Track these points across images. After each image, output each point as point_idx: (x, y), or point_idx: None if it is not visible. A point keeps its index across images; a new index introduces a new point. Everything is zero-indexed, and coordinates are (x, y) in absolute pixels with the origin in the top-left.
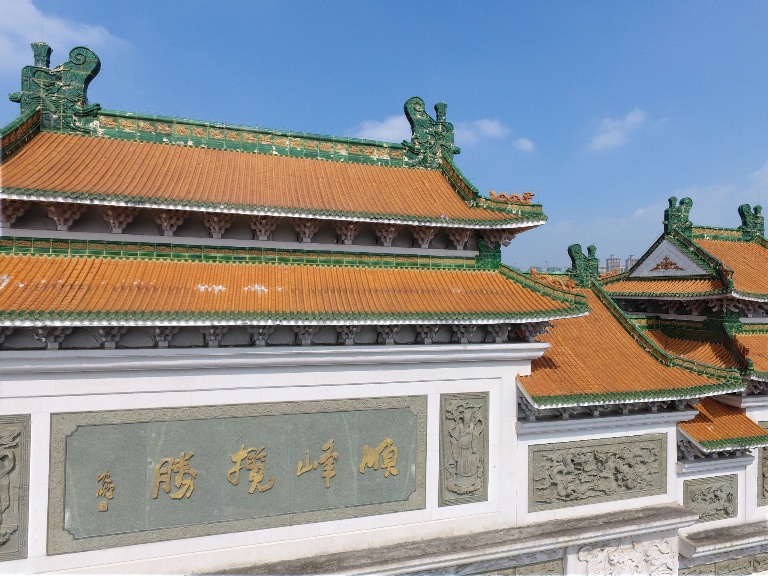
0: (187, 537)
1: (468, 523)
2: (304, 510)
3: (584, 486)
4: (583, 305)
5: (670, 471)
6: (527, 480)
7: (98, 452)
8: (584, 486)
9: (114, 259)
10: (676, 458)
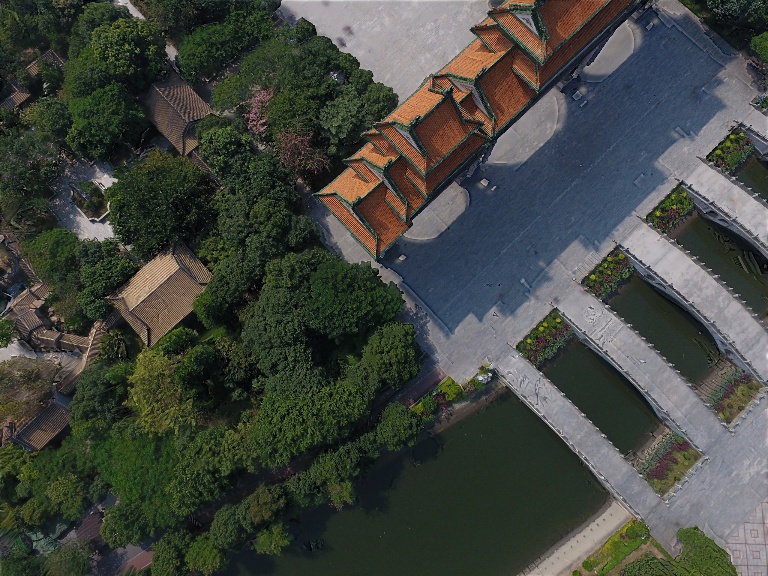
0: None
1: None
2: None
3: None
4: None
5: None
6: None
7: None
8: None
9: None
10: None
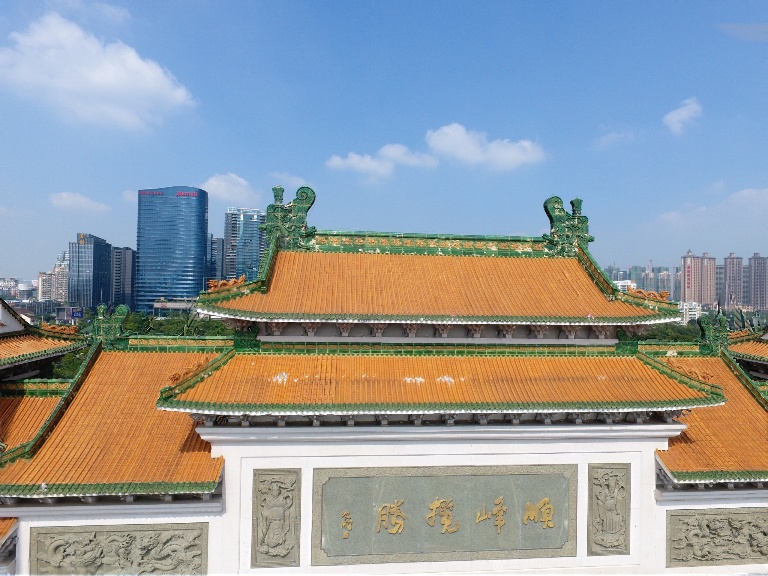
0: (399, 562)
1: (613, 572)
2: (481, 549)
3: (719, 549)
4: (719, 396)
5: None
6: (665, 540)
7: (342, 497)
8: (719, 549)
9: (344, 356)
10: None
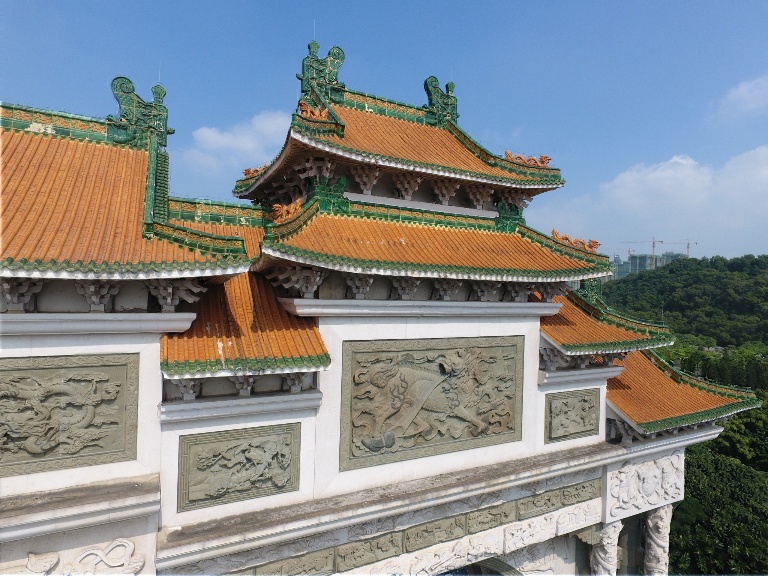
0: None
1: None
2: None
3: None
4: None
5: (145, 420)
6: None
7: None
8: None
9: None
10: (160, 397)
